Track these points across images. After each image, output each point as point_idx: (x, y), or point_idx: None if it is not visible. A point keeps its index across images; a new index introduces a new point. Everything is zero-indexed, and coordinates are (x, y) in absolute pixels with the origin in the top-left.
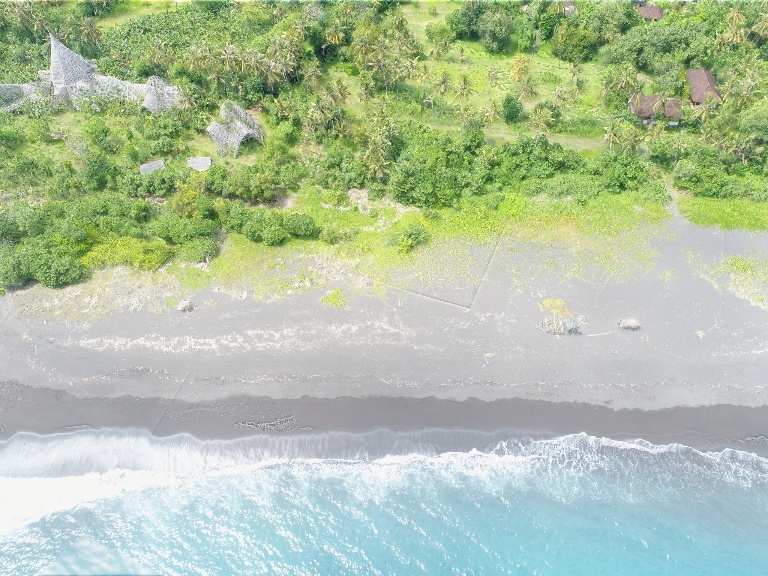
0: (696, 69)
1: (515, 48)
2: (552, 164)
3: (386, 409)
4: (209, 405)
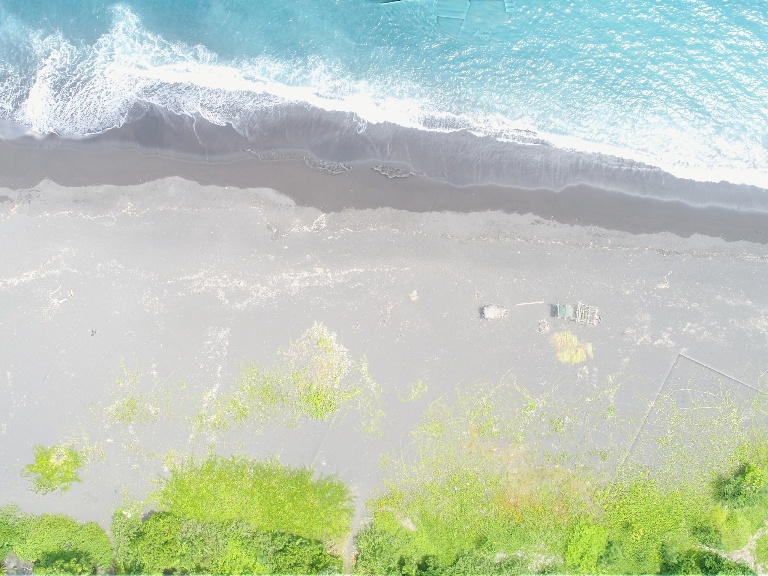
0: None
1: None
2: None
3: None
4: None
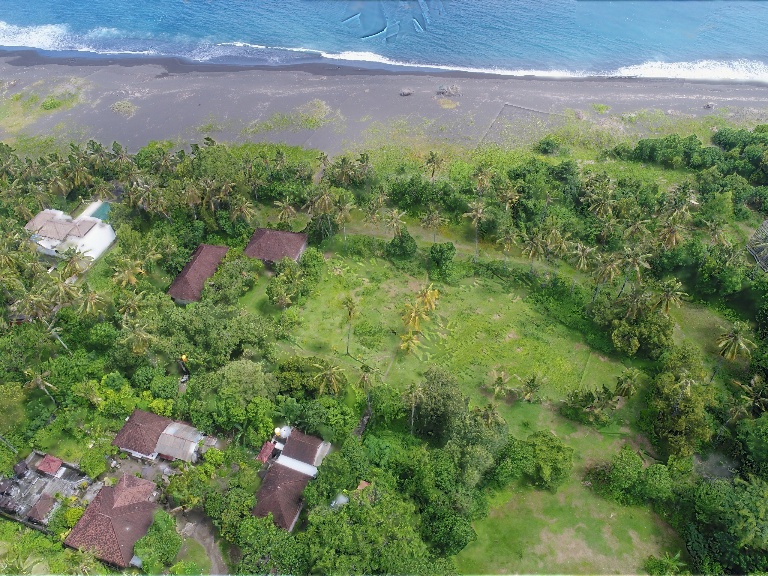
0: (190, 283)
1: None
2: None
3: None
4: (659, 81)
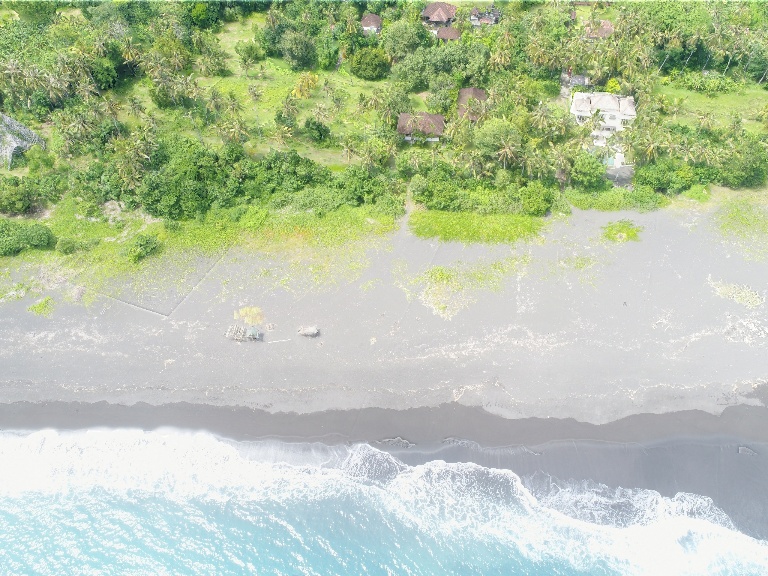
0: (468, 88)
1: (319, 66)
2: (301, 178)
3: (57, 413)
4: None
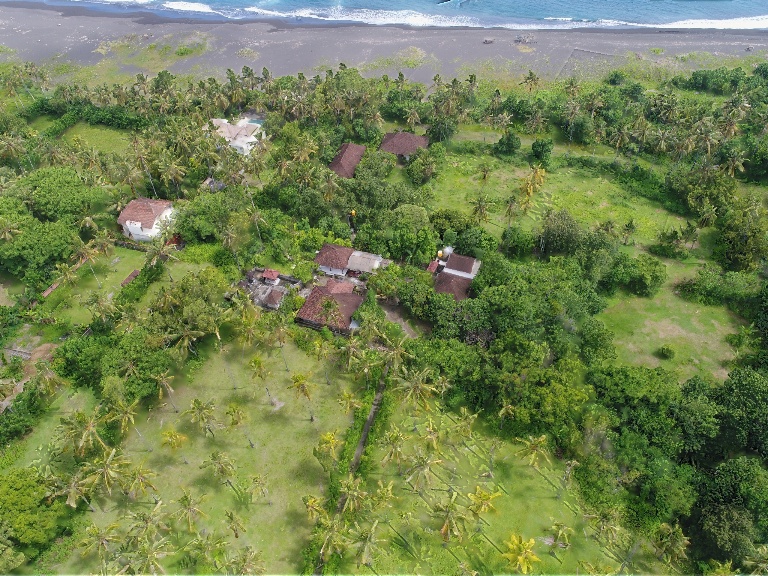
0: (344, 167)
1: (526, 253)
2: None
3: None
4: (704, 33)
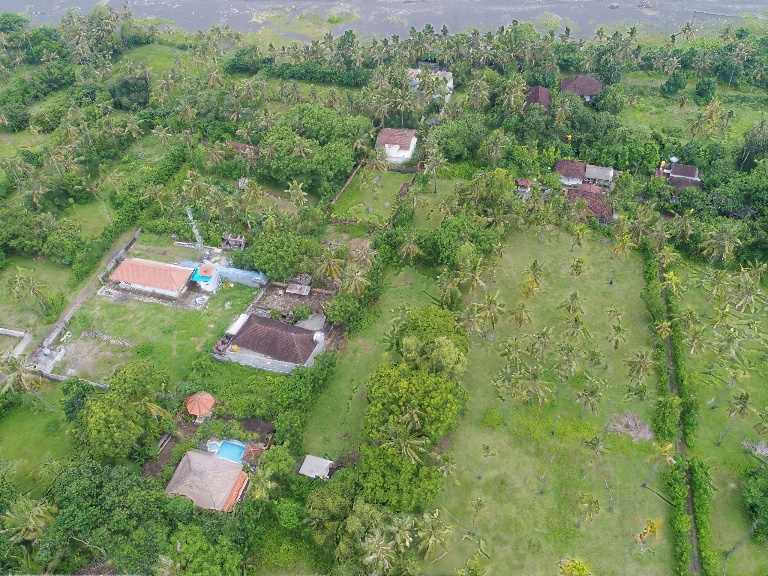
0: (542, 104)
1: None
2: None
3: None
4: None
